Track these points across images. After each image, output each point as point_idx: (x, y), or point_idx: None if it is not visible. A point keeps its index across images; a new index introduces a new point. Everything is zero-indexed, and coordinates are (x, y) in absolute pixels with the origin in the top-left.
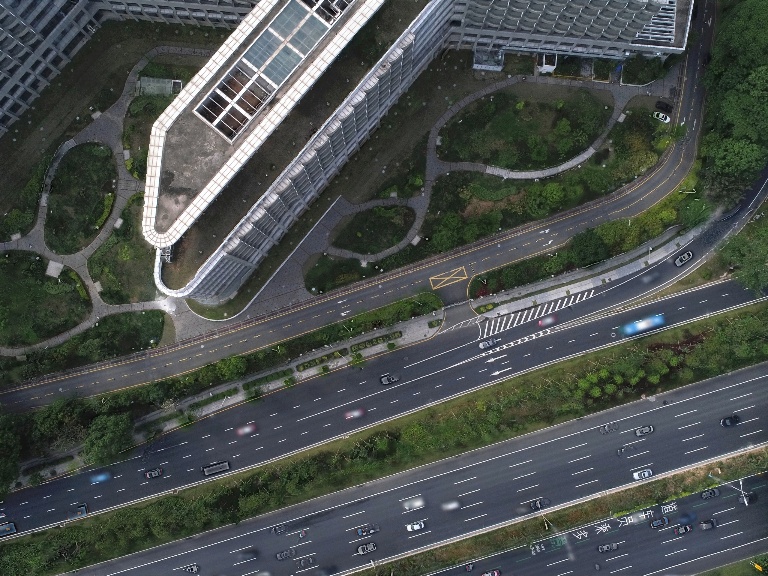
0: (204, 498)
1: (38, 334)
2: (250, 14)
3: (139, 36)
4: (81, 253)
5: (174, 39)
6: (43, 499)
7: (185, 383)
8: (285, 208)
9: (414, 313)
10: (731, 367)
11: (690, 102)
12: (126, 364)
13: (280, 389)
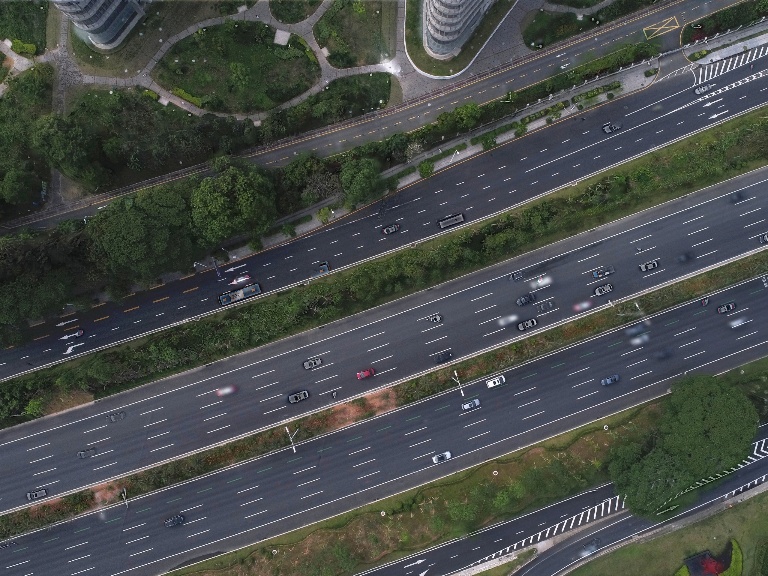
0: (445, 246)
1: (274, 96)
2: None
3: None
4: (306, 21)
5: None
6: (285, 260)
7: (423, 131)
8: None
9: (635, 58)
10: None
11: None
12: (357, 125)
13: (506, 143)
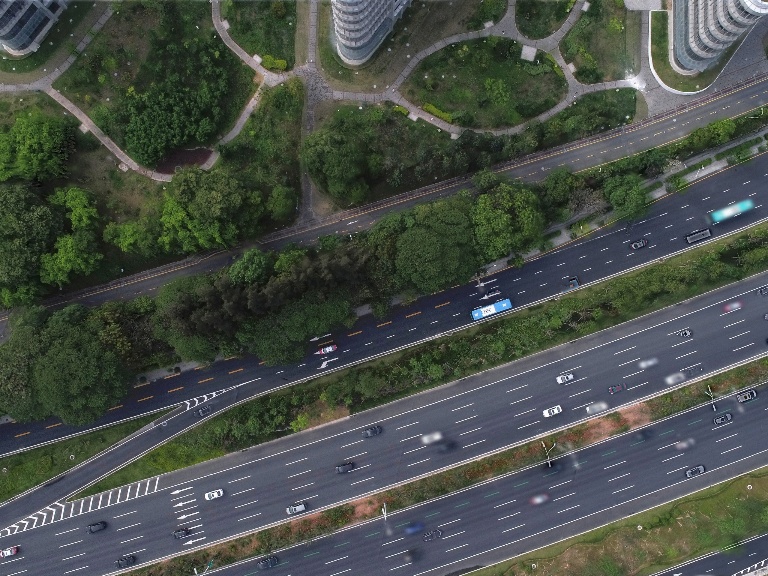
0: (697, 261)
1: (526, 112)
2: None
3: None
4: (552, 37)
5: None
6: (535, 275)
7: (678, 147)
8: None
9: None
10: None
11: None
12: (603, 141)
13: (750, 158)
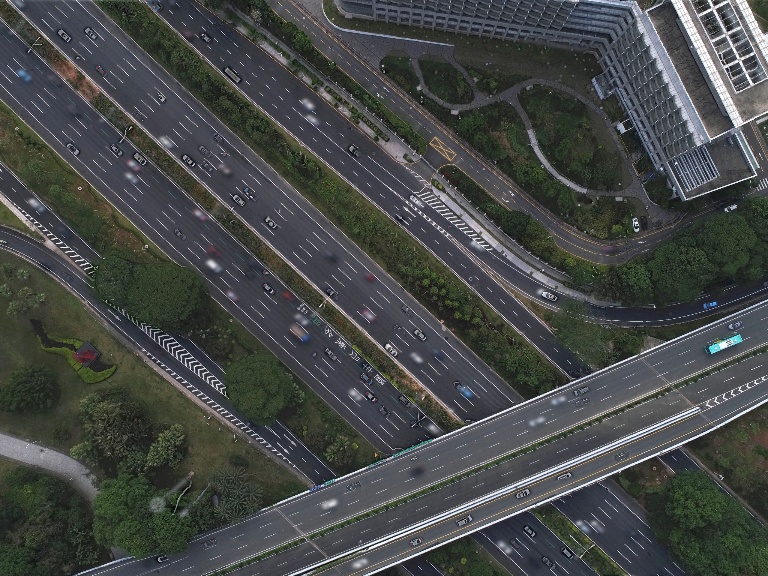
0: None
1: None
2: None
3: None
4: None
5: None
6: None
7: (275, 18)
8: (424, 5)
9: (407, 137)
10: (496, 368)
11: (658, 239)
12: None
13: (306, 85)
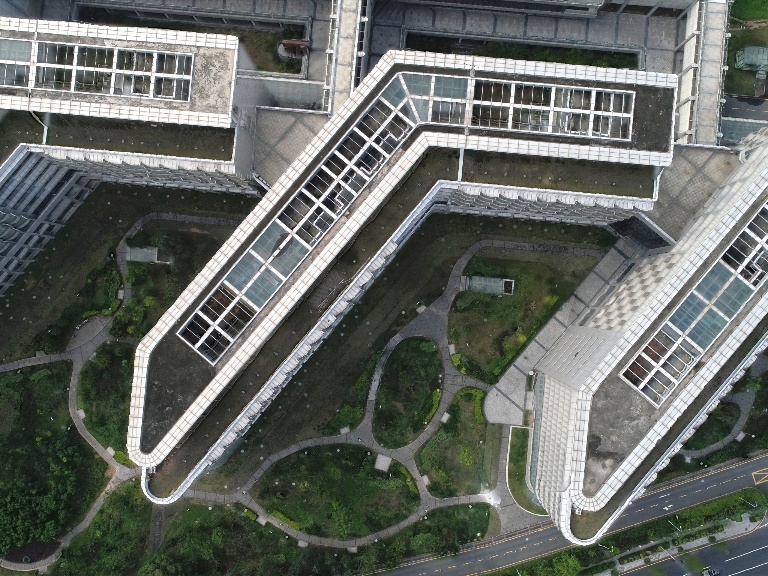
0: None
1: (373, 530)
2: (675, 277)
3: (463, 230)
4: (408, 447)
5: (497, 232)
6: None
7: None
8: None
9: (743, 512)
10: None
11: None
12: (452, 556)
13: None
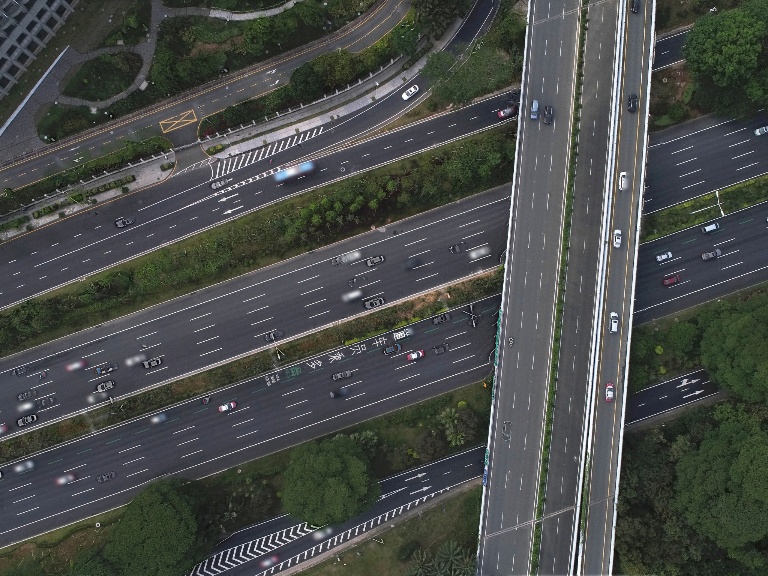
0: None
1: None
2: None
3: None
4: None
5: None
6: None
7: None
8: None
9: (140, 154)
10: (459, 195)
11: None
12: None
13: (18, 237)
